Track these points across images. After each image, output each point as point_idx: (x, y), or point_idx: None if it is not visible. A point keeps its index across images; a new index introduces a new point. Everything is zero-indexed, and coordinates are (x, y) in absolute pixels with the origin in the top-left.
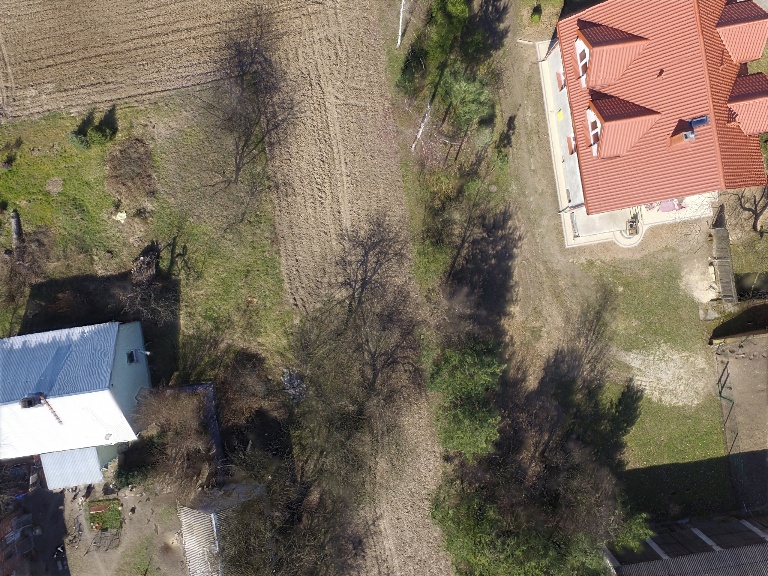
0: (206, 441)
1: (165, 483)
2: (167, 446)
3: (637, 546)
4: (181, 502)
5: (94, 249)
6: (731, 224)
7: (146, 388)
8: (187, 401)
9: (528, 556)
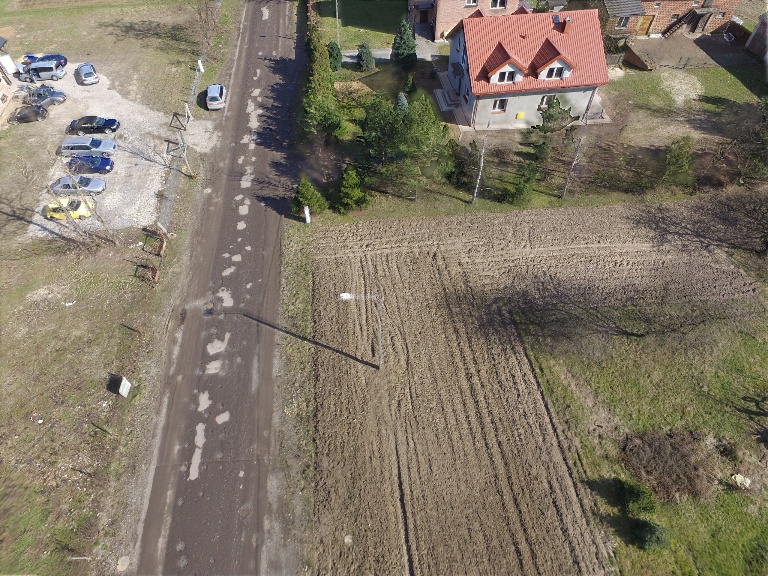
0: None
1: None
2: None
3: None
4: None
5: None
6: None
7: None
8: None
9: None
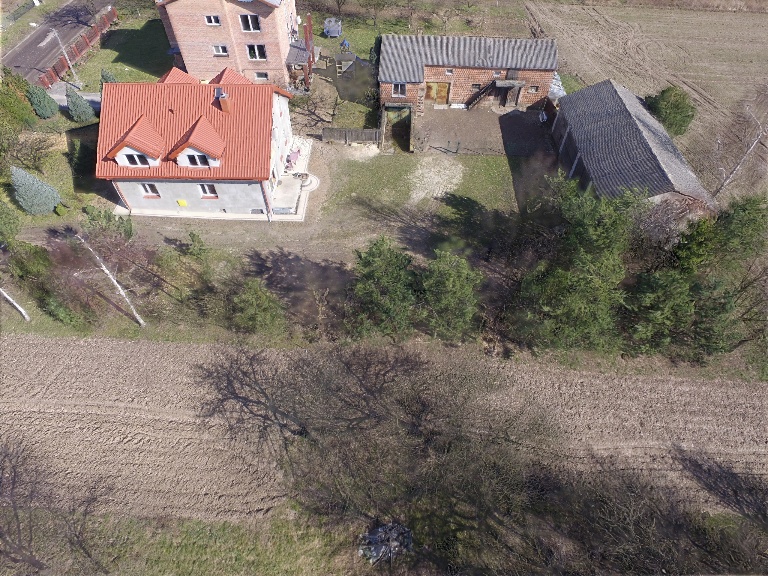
0: None
1: None
2: None
3: None
4: None
5: None
6: None
7: None
8: None
9: (591, 248)
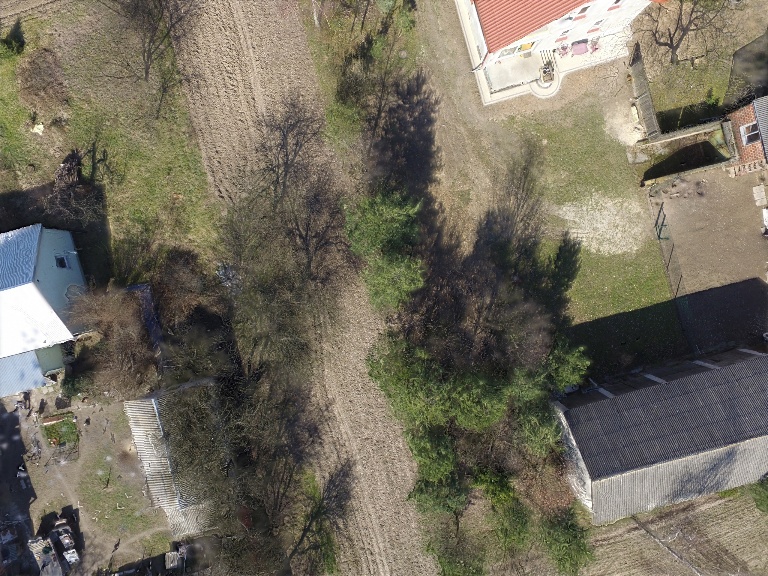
0: (150, 344)
1: (112, 386)
2: (113, 354)
3: (577, 380)
4: (125, 397)
5: (16, 164)
6: (648, 61)
7: (75, 285)
8: (126, 306)
9: None
